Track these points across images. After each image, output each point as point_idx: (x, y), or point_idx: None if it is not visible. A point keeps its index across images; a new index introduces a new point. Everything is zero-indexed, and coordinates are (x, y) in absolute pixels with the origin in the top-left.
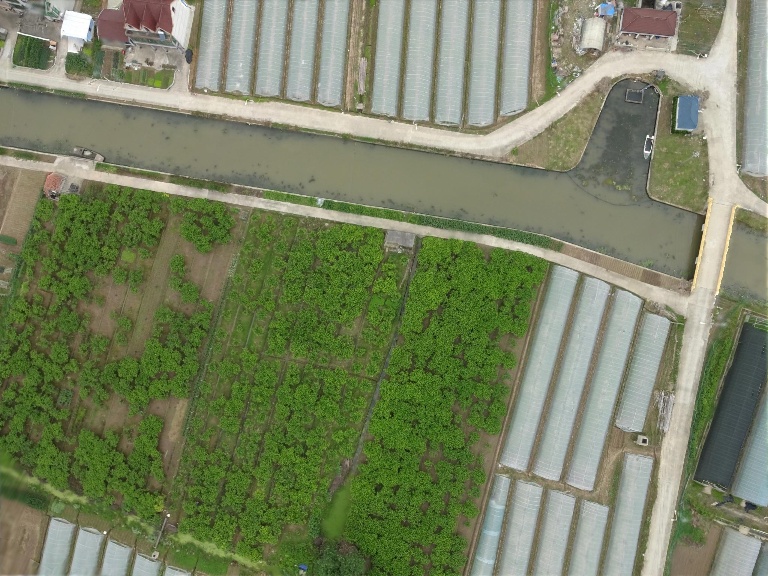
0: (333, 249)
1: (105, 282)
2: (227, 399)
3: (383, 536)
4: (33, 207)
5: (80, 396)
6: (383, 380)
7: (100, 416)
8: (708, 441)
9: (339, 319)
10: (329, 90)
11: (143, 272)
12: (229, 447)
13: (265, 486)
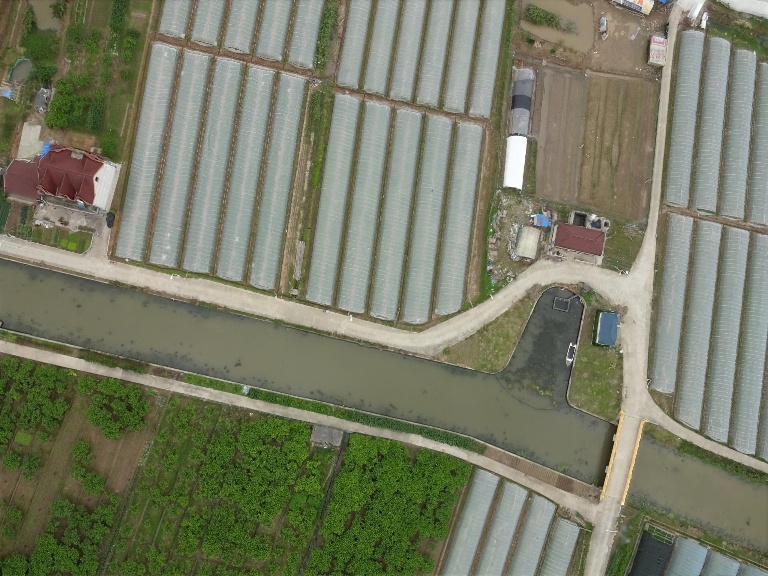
0: (256, 444)
1: None
2: None
3: None
4: None
5: None
6: None
7: None
8: None
9: (258, 518)
10: (263, 274)
11: (40, 458)
12: None
13: None
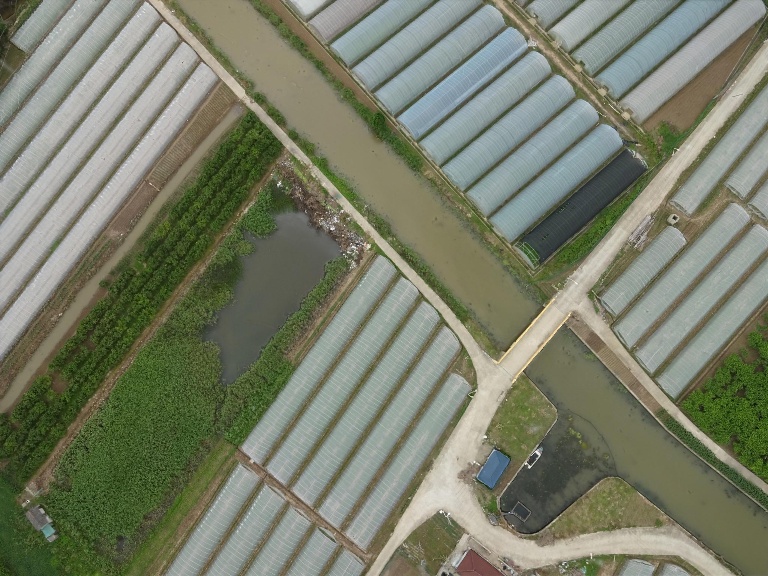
0: None
1: None
2: None
3: None
4: None
5: None
6: None
7: None
8: None
9: None
10: None
11: None
12: None
13: None
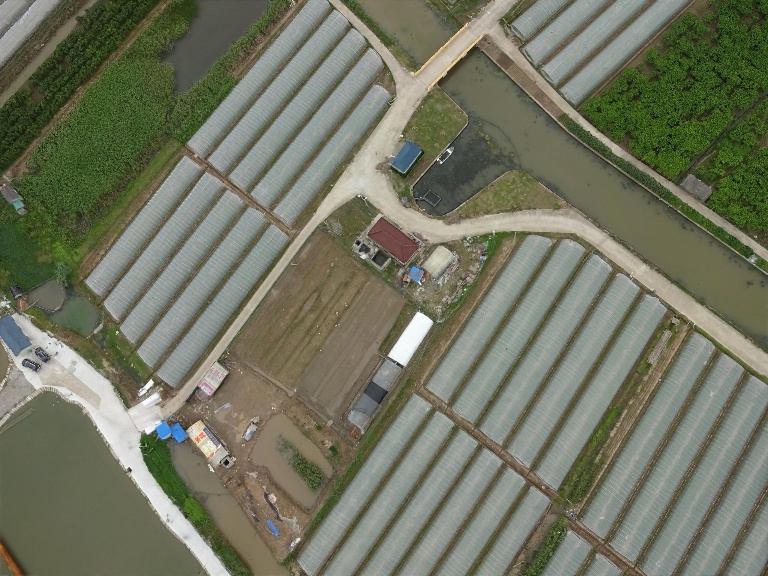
0: (763, 209)
1: None
2: None
3: None
4: None
5: None
6: (765, 90)
7: None
8: None
9: None
10: (701, 350)
11: None
12: None
13: None
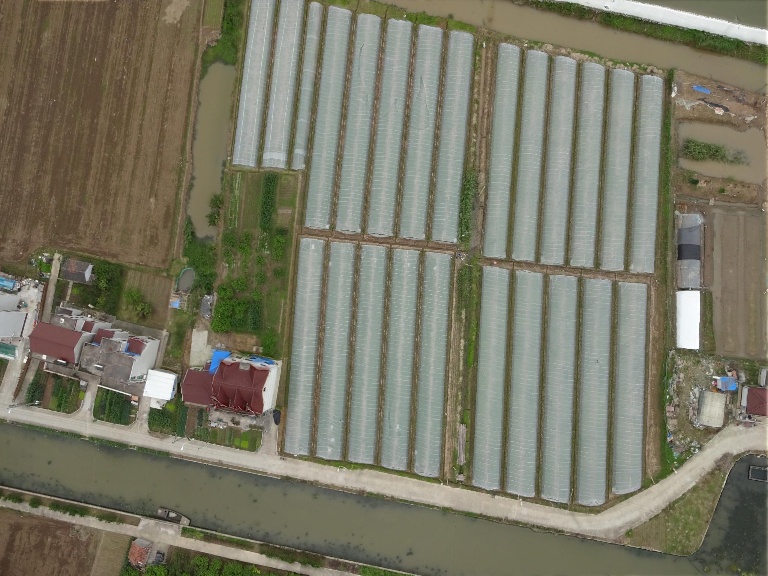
0: None
1: None
2: None
3: None
4: (117, 573)
5: None
6: None
7: None
8: None
9: None
10: (427, 462)
11: None
12: None
13: None
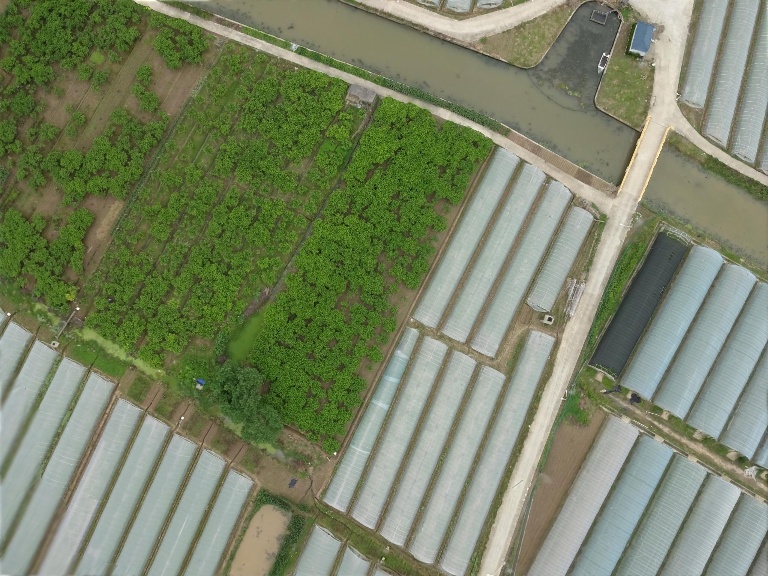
0: (297, 89)
1: (69, 76)
2: (163, 207)
3: (286, 363)
4: None
5: (17, 177)
6: (318, 218)
7: (32, 201)
8: (608, 331)
9: (288, 154)
10: None
11: (109, 74)
12: (154, 254)
13: (181, 297)
